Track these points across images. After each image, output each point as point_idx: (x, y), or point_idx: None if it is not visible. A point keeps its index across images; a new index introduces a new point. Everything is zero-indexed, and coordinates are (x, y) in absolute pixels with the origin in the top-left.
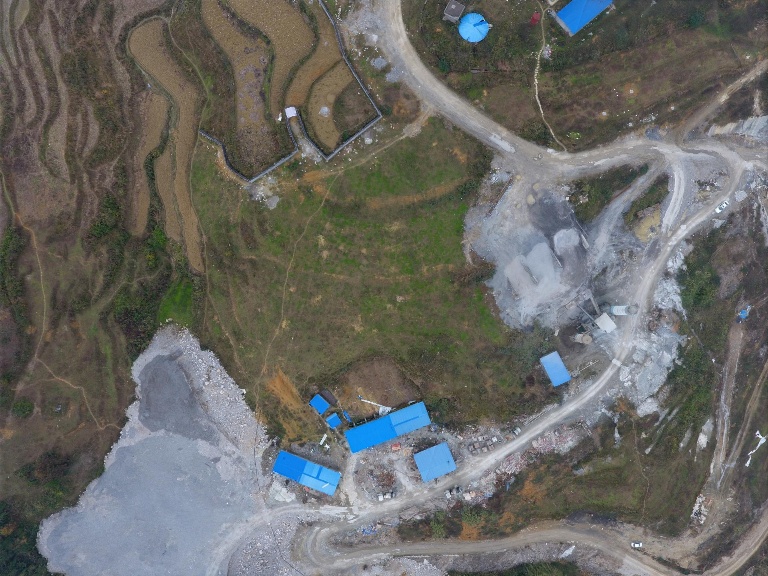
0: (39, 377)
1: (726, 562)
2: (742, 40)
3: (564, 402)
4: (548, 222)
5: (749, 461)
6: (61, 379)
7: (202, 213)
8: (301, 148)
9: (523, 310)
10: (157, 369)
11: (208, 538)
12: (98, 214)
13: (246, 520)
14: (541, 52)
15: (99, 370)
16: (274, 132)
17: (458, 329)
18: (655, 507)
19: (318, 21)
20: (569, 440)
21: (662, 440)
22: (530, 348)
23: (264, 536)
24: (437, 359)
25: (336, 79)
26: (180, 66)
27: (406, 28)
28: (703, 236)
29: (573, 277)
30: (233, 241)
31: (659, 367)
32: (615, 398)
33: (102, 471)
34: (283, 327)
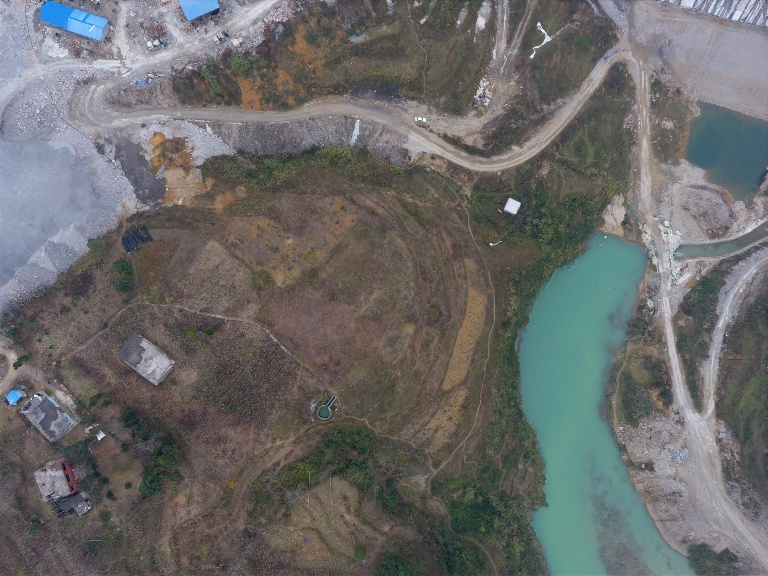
0: None
1: (516, 152)
2: None
3: None
4: None
5: (534, 54)
6: None
7: None
8: None
9: None
10: None
11: None
12: None
13: (19, 75)
14: None
15: None
16: None
17: None
18: (435, 81)
19: None
20: None
21: (435, 10)
22: None
23: (39, 93)
24: None
25: None
26: None
27: None
28: None
29: None
30: None
31: None
32: None
33: None
34: None
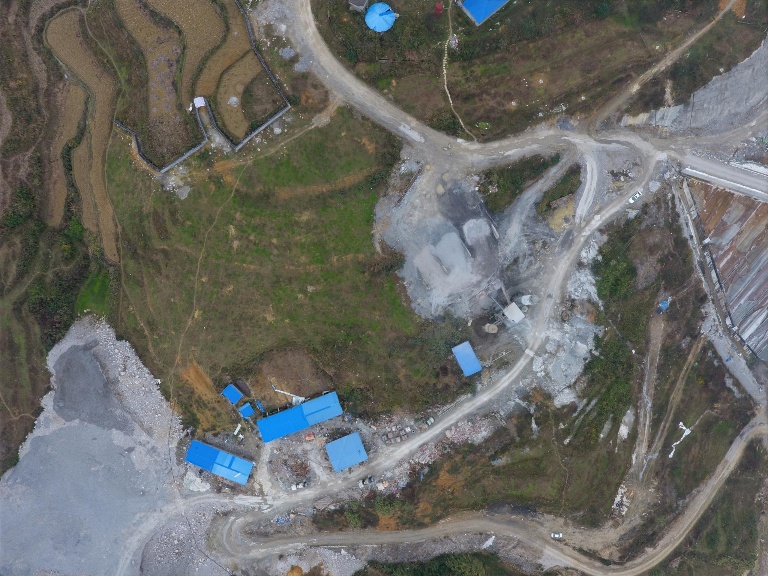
0: None
1: (650, 553)
2: (651, 30)
3: (478, 392)
4: (457, 212)
5: (673, 452)
6: None
7: (117, 203)
8: (211, 138)
9: (434, 300)
10: (71, 359)
11: (122, 527)
12: (10, 204)
13: (160, 510)
14: (448, 42)
15: (12, 360)
16: (185, 122)
17: (369, 319)
18: (575, 498)
19: (228, 11)
20: (483, 430)
21: (580, 431)
22: (442, 338)
23: (179, 526)
24: (350, 349)
25: (245, 69)
26: (96, 57)
27: (314, 18)
28: (617, 226)
29: (484, 267)
30: (146, 231)
31: (574, 357)
32: (529, 388)
33: (16, 461)
34: (195, 317)
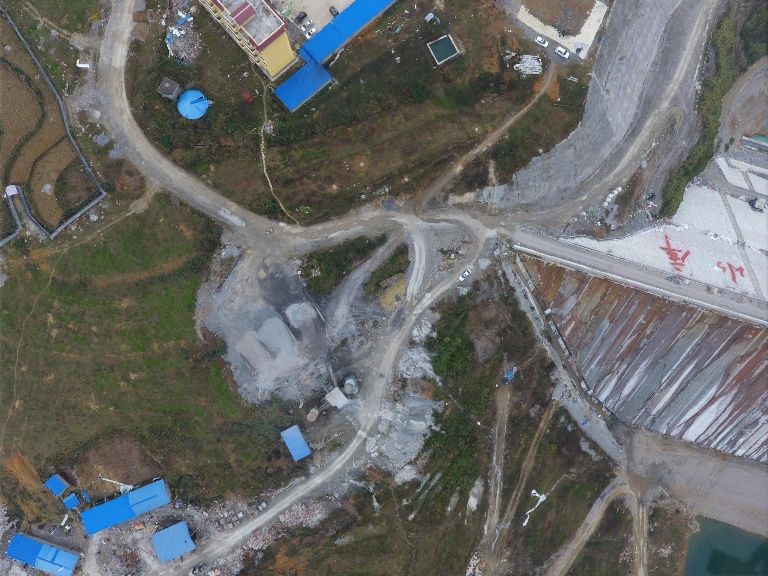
0: None
1: None
2: (470, 113)
3: (311, 475)
4: (279, 297)
5: (527, 520)
6: None
7: None
8: (25, 226)
9: (261, 384)
10: None
11: None
12: None
13: None
14: (263, 128)
15: None
16: (0, 209)
17: (195, 405)
18: (423, 573)
19: (44, 96)
20: (317, 513)
21: (425, 506)
22: (271, 422)
23: None
24: (178, 435)
25: (60, 156)
26: None
27: (129, 104)
28: (450, 303)
29: (311, 350)
30: None
31: (411, 435)
32: (364, 469)
33: None
34: (16, 407)
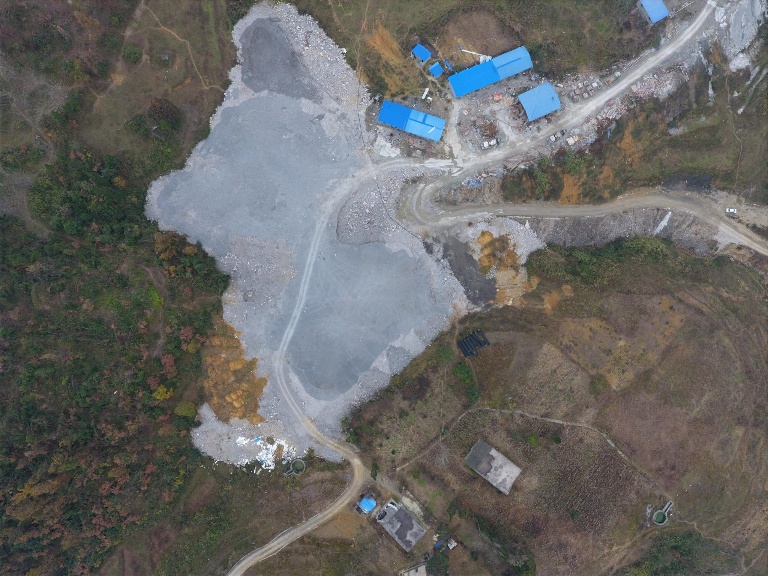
0: (147, 24)
1: None
2: None
3: (661, 46)
4: None
5: None
6: (167, 29)
7: None
8: None
9: None
10: (258, 29)
11: (316, 192)
12: None
13: (352, 175)
14: None
15: (202, 27)
16: None
17: None
18: (748, 171)
19: None
20: (668, 84)
21: (754, 99)
22: None
23: (370, 193)
24: (536, 4)
25: None
26: None
27: None
28: None
29: None
30: None
31: (751, 14)
32: (710, 42)
33: (208, 132)
34: None
